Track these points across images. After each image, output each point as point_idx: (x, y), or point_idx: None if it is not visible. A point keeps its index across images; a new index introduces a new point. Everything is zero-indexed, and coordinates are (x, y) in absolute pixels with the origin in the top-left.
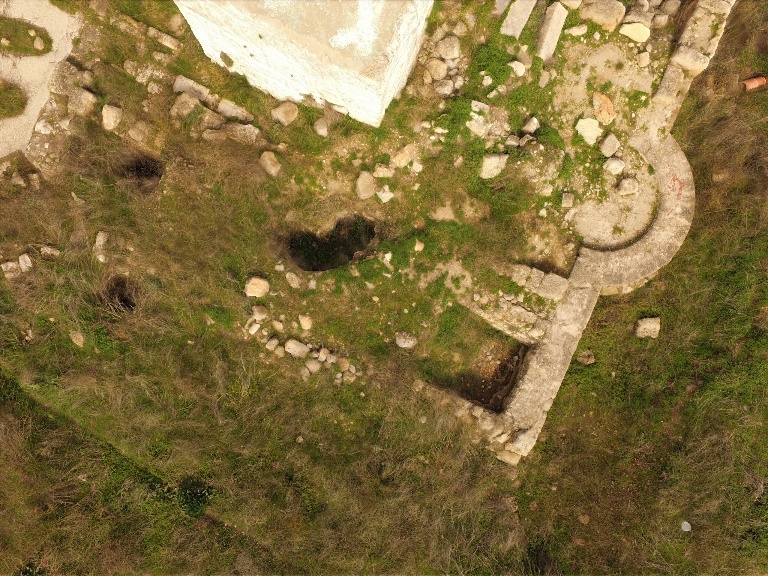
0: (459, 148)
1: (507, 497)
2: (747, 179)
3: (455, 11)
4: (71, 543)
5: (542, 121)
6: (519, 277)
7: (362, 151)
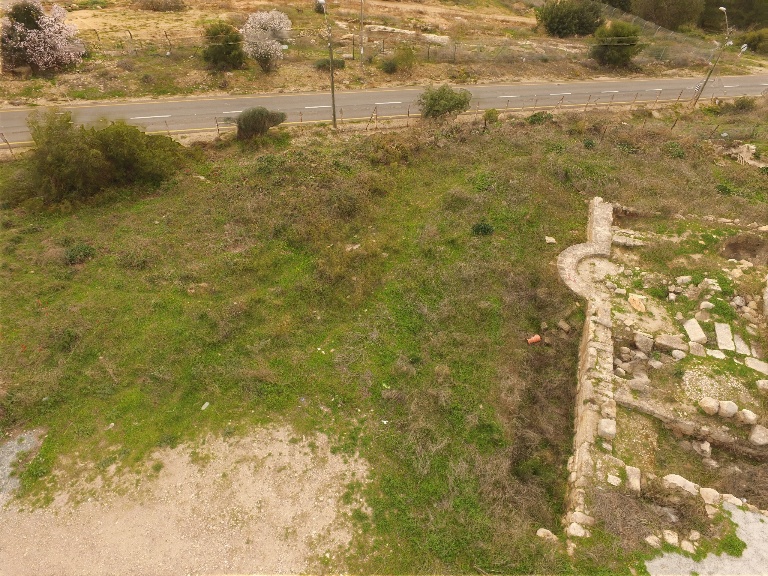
0: (712, 274)
1: (587, 195)
2: (529, 287)
3: (764, 334)
4: (760, 181)
5: (666, 302)
6: (639, 241)
7: (759, 277)
